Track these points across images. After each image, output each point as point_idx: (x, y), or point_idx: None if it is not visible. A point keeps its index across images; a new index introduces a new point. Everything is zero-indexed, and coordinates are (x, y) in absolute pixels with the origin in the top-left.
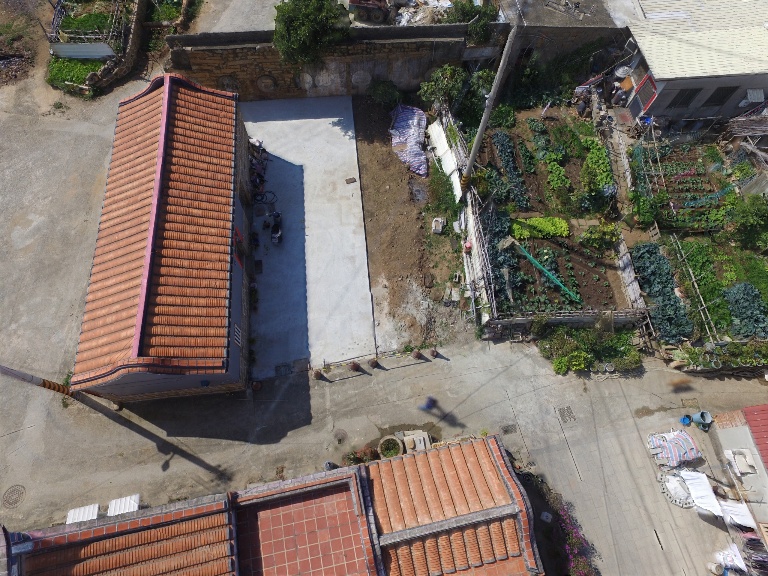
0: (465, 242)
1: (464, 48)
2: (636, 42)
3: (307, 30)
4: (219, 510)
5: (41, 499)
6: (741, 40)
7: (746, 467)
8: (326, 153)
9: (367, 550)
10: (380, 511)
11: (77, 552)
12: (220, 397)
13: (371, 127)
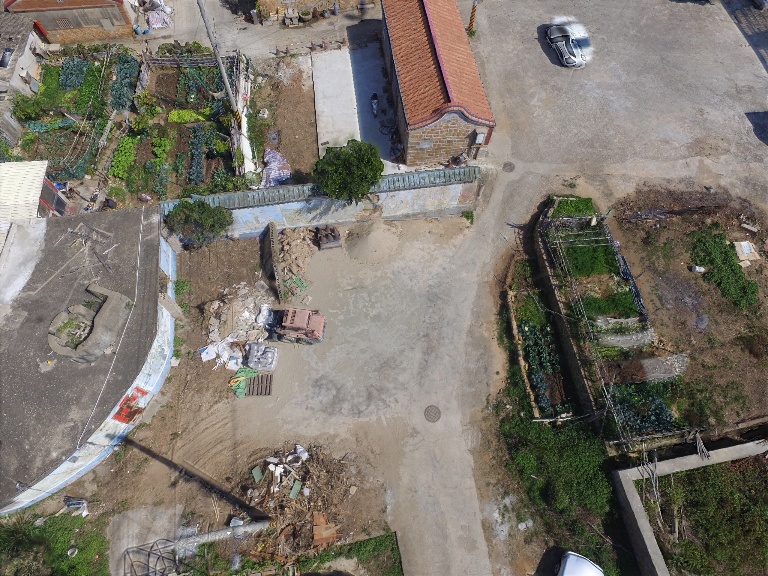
0: None
1: None
2: None
3: None
4: None
5: (466, 0)
6: None
7: (131, 0)
8: None
9: None
10: None
11: None
12: None
13: None
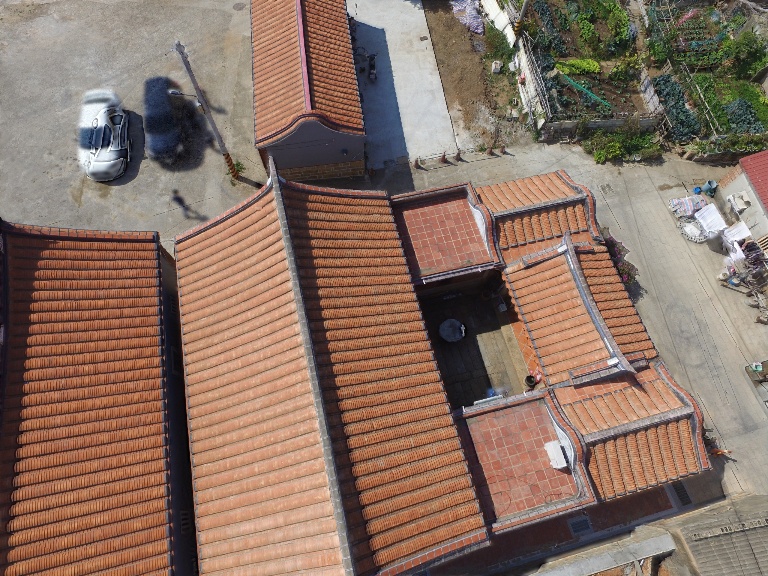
0: None
1: None
2: None
3: None
4: (383, 197)
5: None
6: None
7: (743, 205)
8: (401, 20)
9: (487, 216)
10: (489, 206)
11: (307, 196)
12: (346, 180)
13: (435, 1)
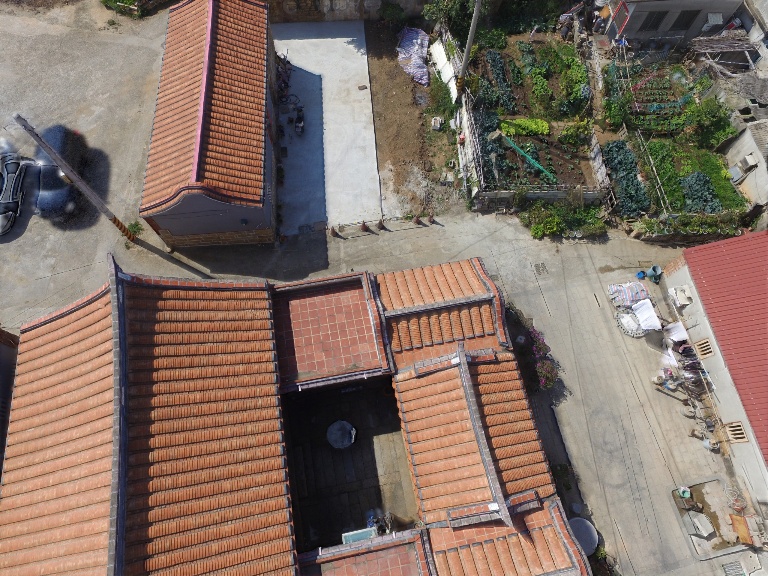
0: None
1: None
2: None
3: None
4: (261, 288)
5: None
6: None
7: (685, 300)
8: (341, 66)
9: (375, 316)
10: (385, 300)
11: (160, 293)
12: (253, 247)
13: (380, 46)
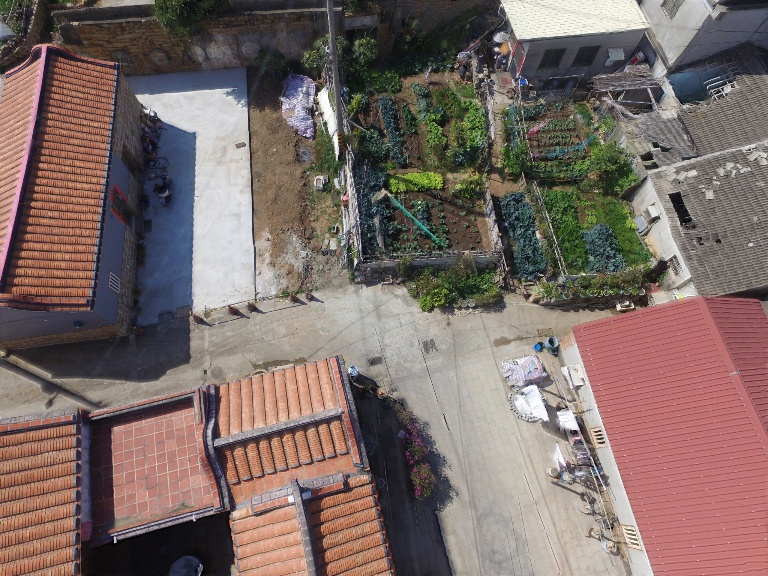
0: None
1: (343, 17)
2: (503, 7)
3: (182, 1)
4: (67, 422)
5: None
6: (600, 3)
7: (579, 380)
8: (219, 121)
9: (200, 449)
10: (222, 421)
11: None
12: (104, 342)
13: (263, 96)
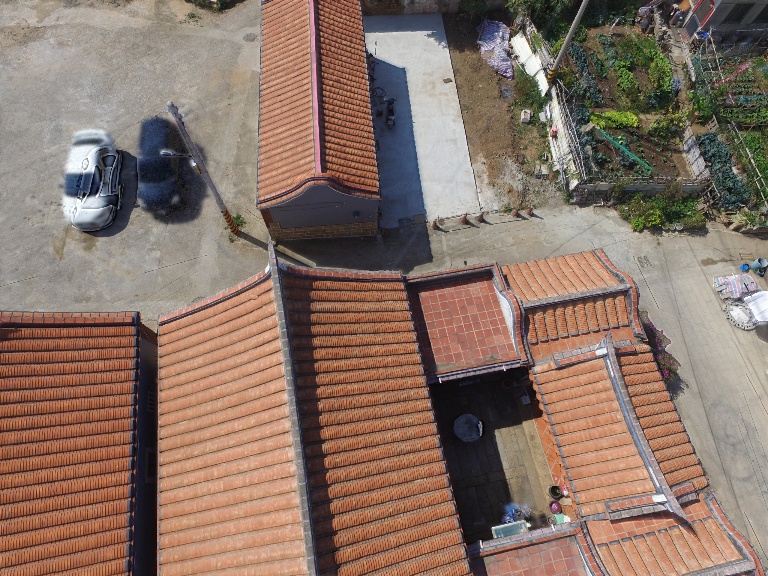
0: (550, 129)
1: None
2: None
3: None
4: (397, 279)
5: None
6: None
7: None
8: (424, 59)
9: (515, 307)
10: (517, 291)
11: (310, 283)
12: (356, 240)
13: (461, 39)
